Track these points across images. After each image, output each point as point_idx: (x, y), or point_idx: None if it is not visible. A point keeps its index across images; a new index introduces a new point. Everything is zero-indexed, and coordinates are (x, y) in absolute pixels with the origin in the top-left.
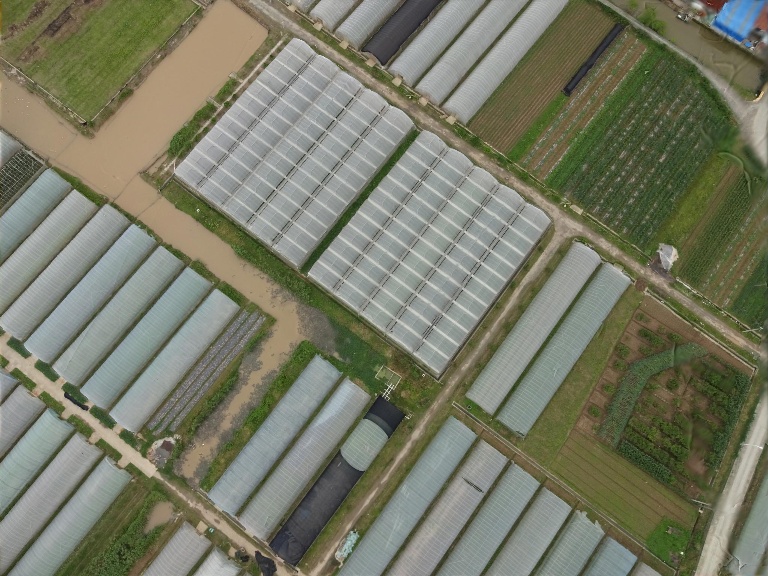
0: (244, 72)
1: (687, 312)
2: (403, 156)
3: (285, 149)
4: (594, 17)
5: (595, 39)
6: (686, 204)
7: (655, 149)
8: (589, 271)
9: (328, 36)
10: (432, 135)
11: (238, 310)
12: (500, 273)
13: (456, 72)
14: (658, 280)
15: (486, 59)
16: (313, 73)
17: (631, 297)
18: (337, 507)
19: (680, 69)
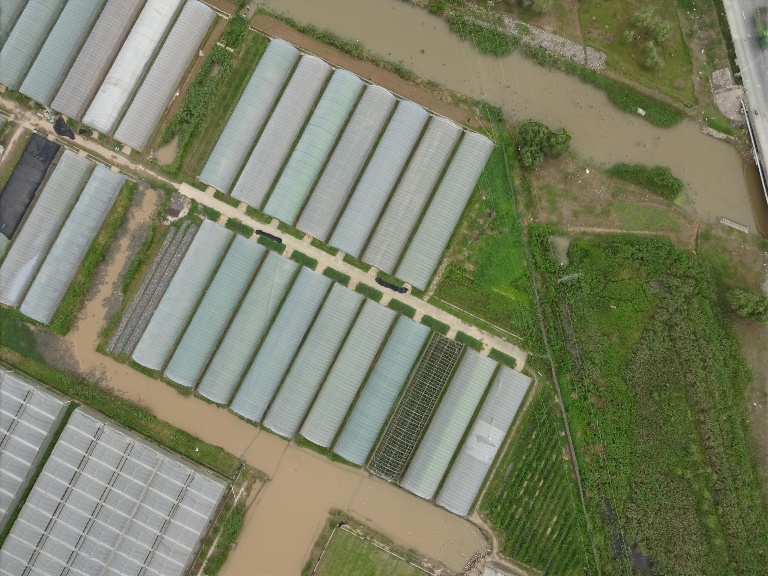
0: None
1: None
2: None
3: (105, 536)
4: None
5: None
6: None
7: None
8: None
9: None
10: None
11: None
12: None
13: None
14: None
15: None
16: None
17: None
18: (5, 189)
19: None
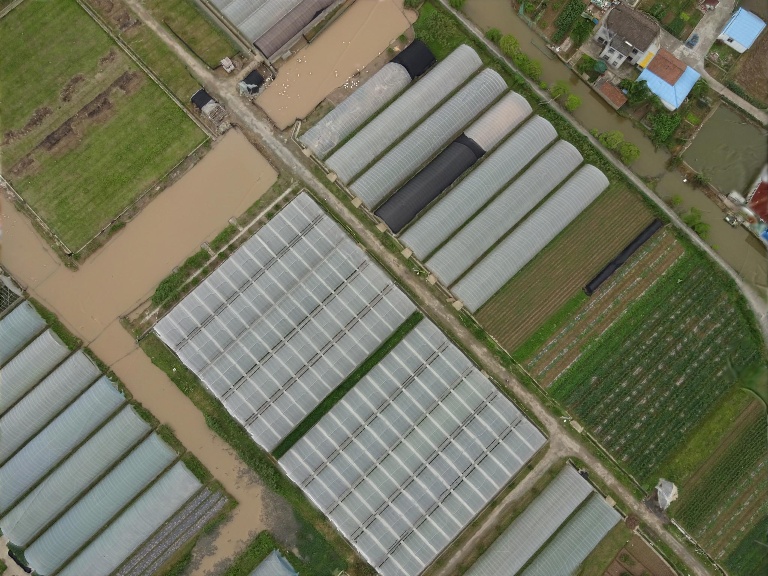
0: (245, 219)
1: (676, 559)
2: (399, 344)
3: (274, 321)
4: (633, 207)
5: (630, 233)
6: (697, 438)
7: (674, 370)
8: (578, 502)
9: (341, 190)
10: (434, 326)
11: (200, 487)
12: (482, 493)
13: (472, 255)
14: (651, 519)
15: (507, 243)
16: (317, 238)
17: (619, 534)
18: None
19: (717, 282)
